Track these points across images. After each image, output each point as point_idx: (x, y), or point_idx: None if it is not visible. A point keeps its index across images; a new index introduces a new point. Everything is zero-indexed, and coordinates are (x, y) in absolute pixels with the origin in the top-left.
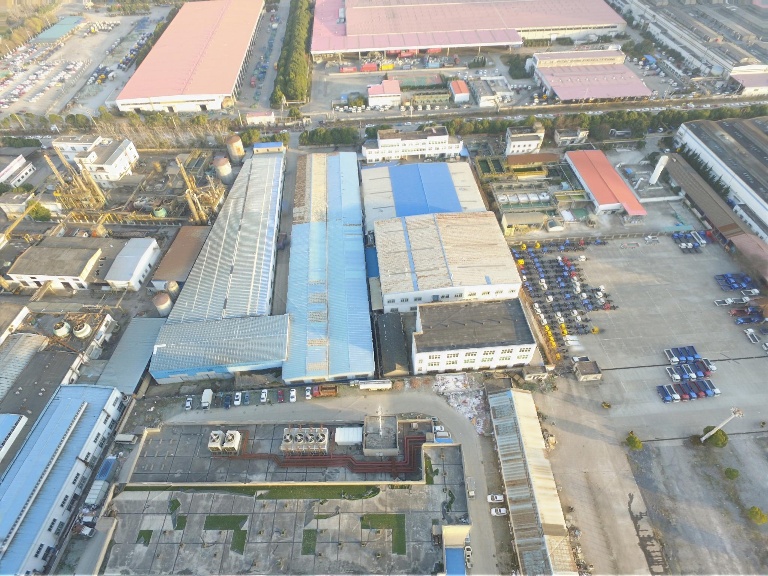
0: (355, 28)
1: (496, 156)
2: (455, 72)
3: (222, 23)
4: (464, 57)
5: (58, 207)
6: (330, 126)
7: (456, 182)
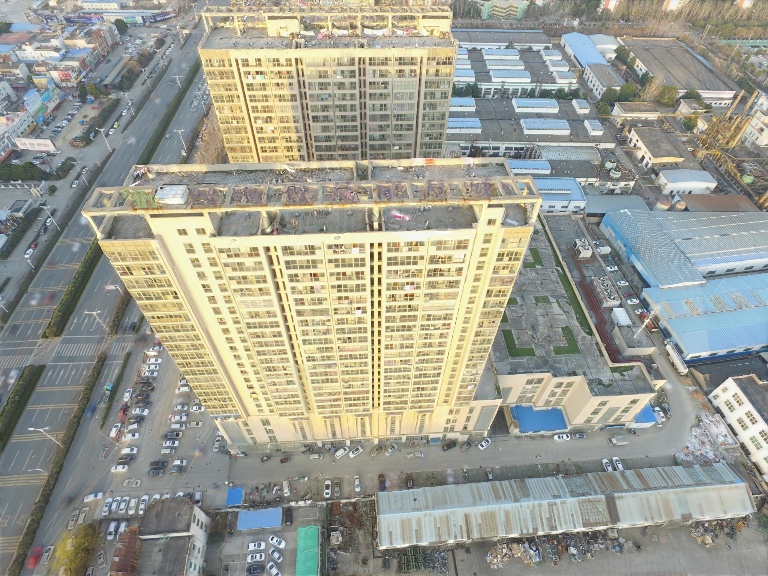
0: None
1: None
2: None
3: None
4: None
5: (704, 128)
6: None
7: None
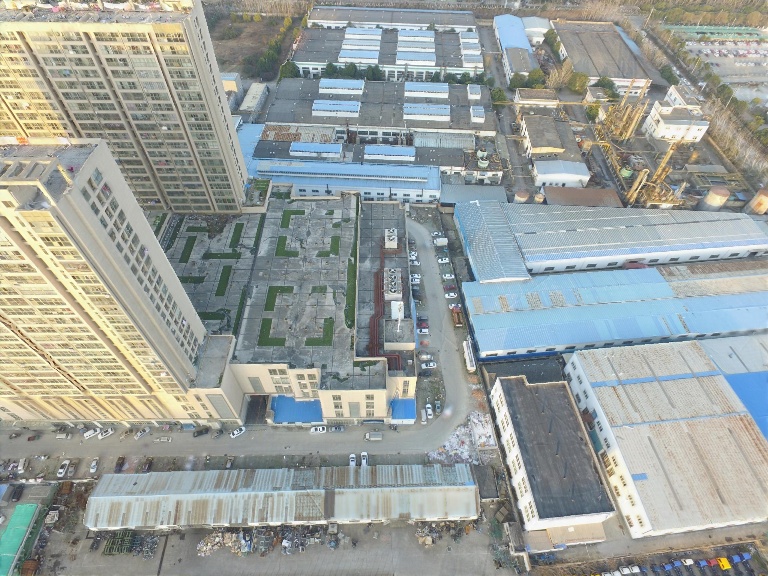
0: None
1: None
2: None
3: None
4: None
5: (603, 117)
6: None
7: None
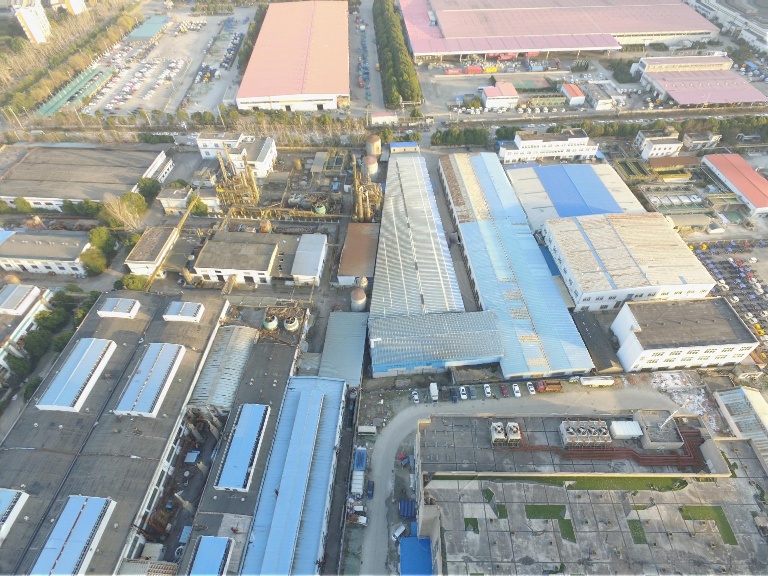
0: (452, 31)
1: (635, 159)
2: (560, 75)
3: (316, 24)
4: (563, 61)
5: (217, 203)
6: (455, 127)
7: (606, 183)
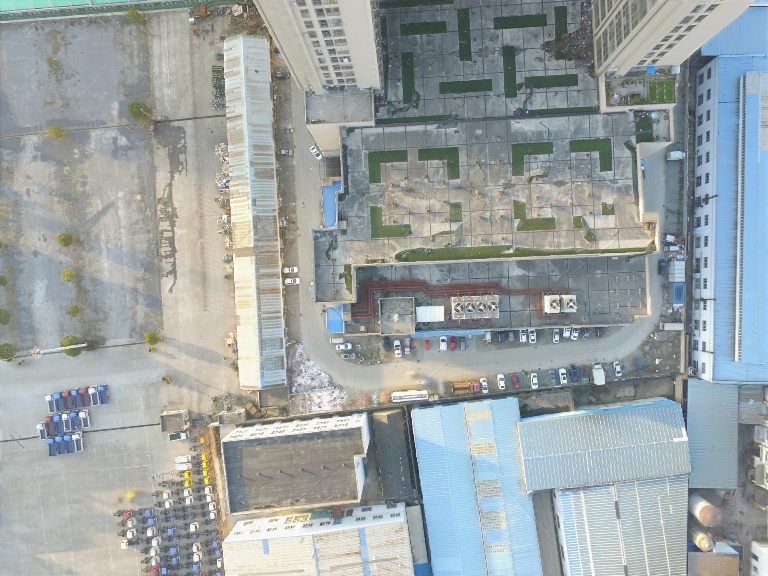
0: None
1: None
2: None
3: None
4: None
5: None
6: None
7: None
